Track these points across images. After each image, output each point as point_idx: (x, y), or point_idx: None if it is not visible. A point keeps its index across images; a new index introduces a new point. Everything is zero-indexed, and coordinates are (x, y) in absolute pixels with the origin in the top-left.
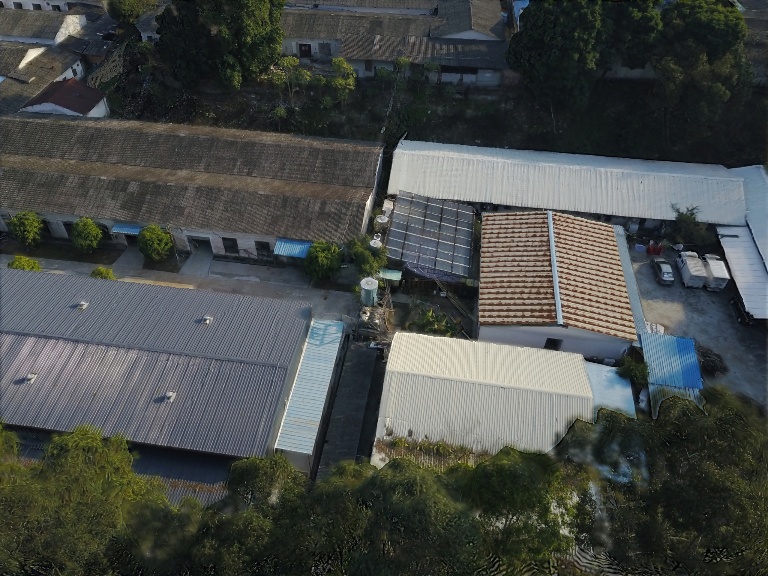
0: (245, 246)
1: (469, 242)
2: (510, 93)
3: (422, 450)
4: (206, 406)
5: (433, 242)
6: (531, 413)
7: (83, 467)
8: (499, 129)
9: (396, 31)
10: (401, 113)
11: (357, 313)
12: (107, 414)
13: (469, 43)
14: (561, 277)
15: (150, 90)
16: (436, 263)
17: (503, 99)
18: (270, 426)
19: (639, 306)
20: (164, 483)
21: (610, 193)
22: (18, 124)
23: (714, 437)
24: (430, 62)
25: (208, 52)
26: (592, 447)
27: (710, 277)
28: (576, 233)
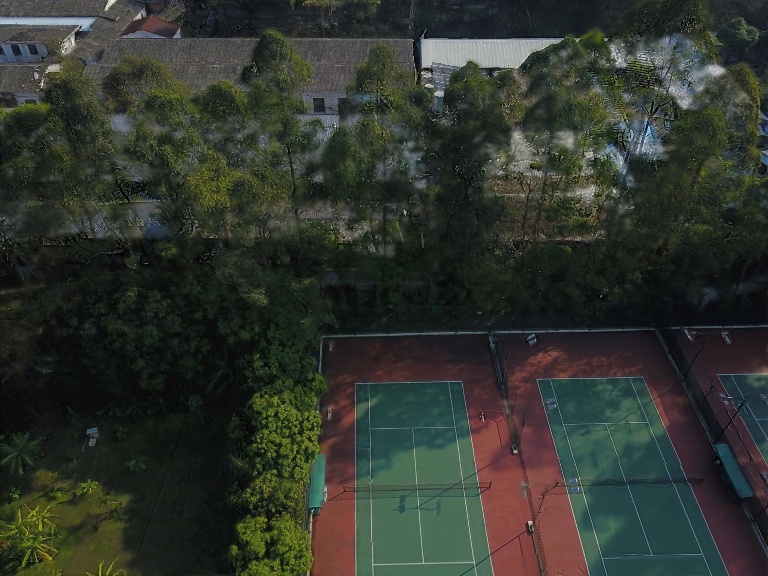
0: (330, 104)
1: None
2: (494, 2)
3: (496, 178)
4: None
5: None
6: None
7: None
8: (490, 27)
9: None
10: (416, 21)
11: None
12: None
13: None
14: None
15: (218, 18)
16: None
17: (489, 7)
18: None
19: None
20: None
21: None
22: (128, 42)
23: None
24: None
25: None
26: None
27: None
28: None
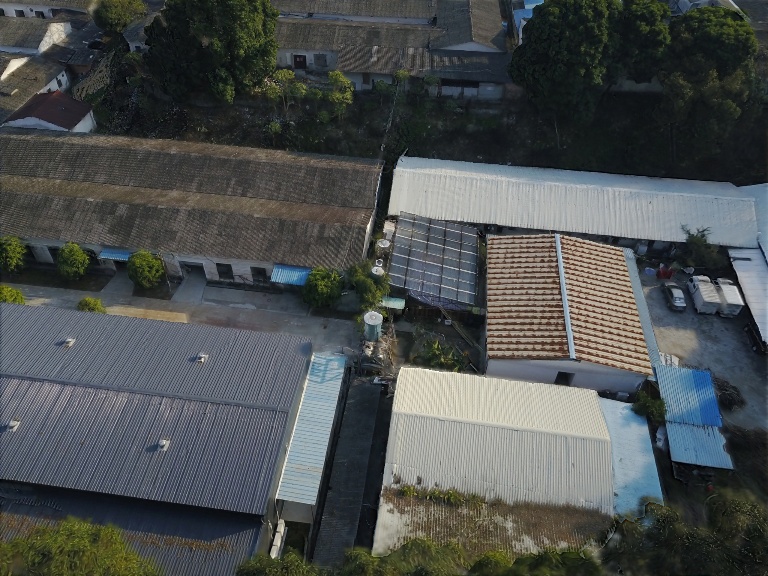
0: (240, 272)
1: (474, 267)
2: (512, 107)
3: (432, 500)
4: (202, 455)
5: (437, 268)
6: (546, 458)
7: (68, 575)
8: (501, 144)
9: (394, 42)
10: (400, 128)
11: (358, 343)
12: (96, 465)
13: (470, 55)
14: (572, 306)
15: (139, 103)
16: (441, 291)
17: (505, 113)
18: (271, 477)
19: (652, 336)
20: (158, 541)
21: (618, 214)
22: None
23: None
24: (430, 75)
25: (199, 65)
26: (650, 564)
27: (724, 303)
28: (585, 258)
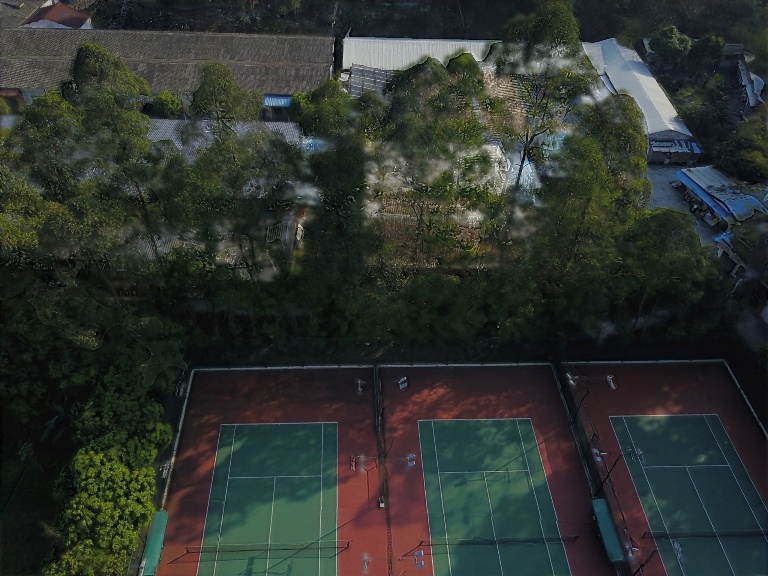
0: None
1: None
2: None
3: None
4: None
5: None
6: None
7: None
8: (421, 27)
9: None
10: (343, 18)
11: None
12: None
13: None
14: None
15: (131, 8)
16: None
17: (422, 5)
18: None
19: None
20: None
21: None
22: (26, 32)
23: (551, 4)
24: None
25: None
26: None
27: None
28: None
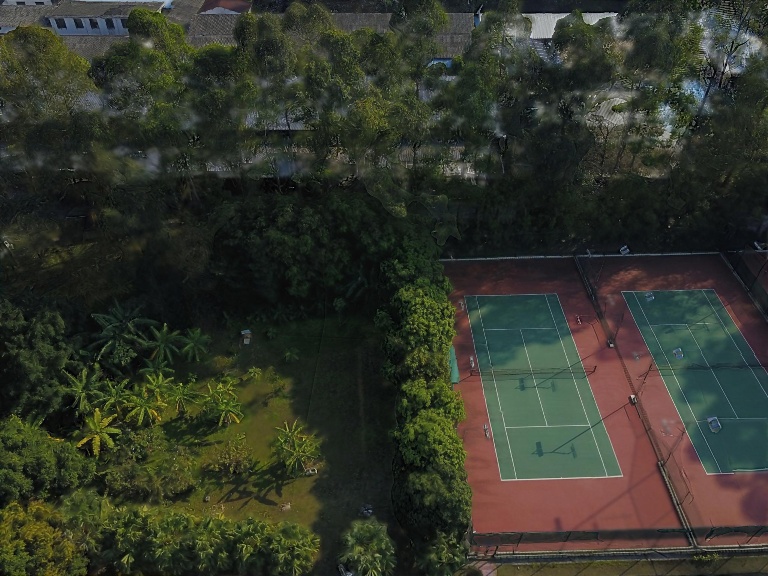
0: None
1: None
2: None
3: None
4: None
5: None
6: None
7: None
8: (539, 4)
9: None
10: None
11: None
12: None
13: None
14: None
15: None
16: None
17: None
18: None
19: None
20: None
21: None
22: (212, 17)
23: None
24: None
25: None
26: None
27: None
28: None
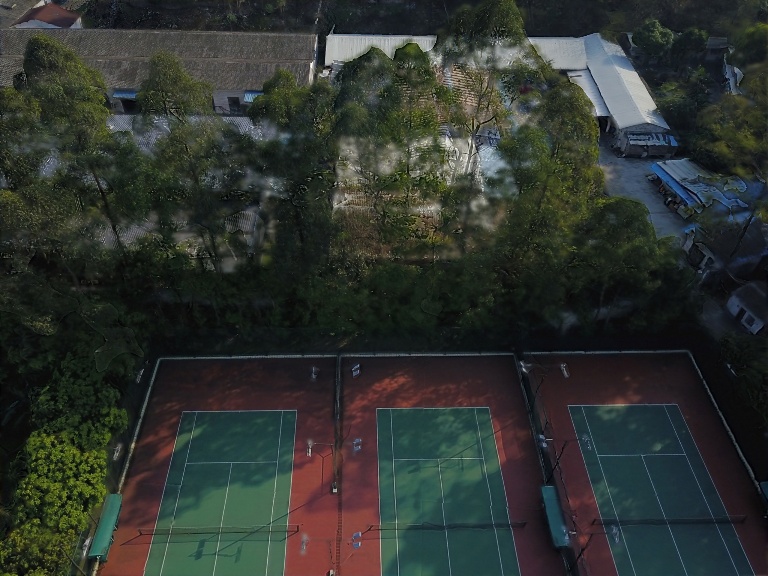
0: (220, 103)
1: None
2: None
3: None
4: None
5: None
6: None
7: None
8: (406, 23)
9: None
10: (329, 15)
11: None
12: None
13: None
14: None
15: (120, 8)
16: None
17: (407, 1)
18: None
19: None
20: None
21: None
22: (15, 32)
23: None
24: None
25: None
26: None
27: None
28: None
